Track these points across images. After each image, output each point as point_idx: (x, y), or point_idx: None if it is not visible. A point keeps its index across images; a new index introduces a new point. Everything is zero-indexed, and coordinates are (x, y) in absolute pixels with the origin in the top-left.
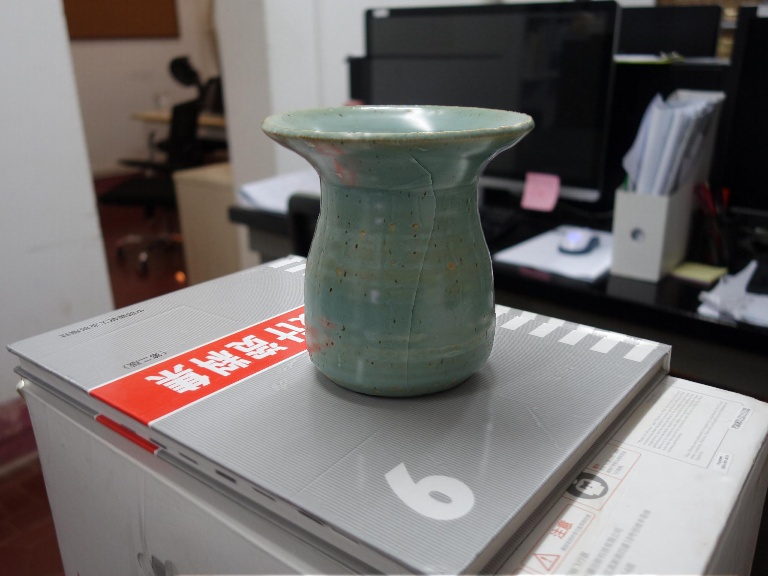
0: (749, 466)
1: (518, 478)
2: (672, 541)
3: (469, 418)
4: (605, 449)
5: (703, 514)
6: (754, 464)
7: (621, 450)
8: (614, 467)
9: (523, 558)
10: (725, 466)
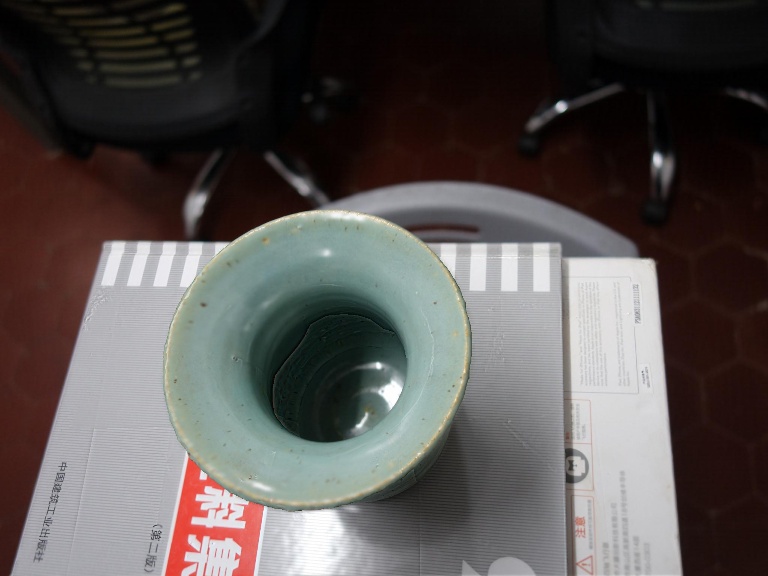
0: (663, 372)
1: (548, 529)
2: (649, 497)
3: (472, 469)
4: None
5: (656, 454)
6: None
7: (575, 404)
8: (580, 430)
9: (572, 572)
10: (649, 383)
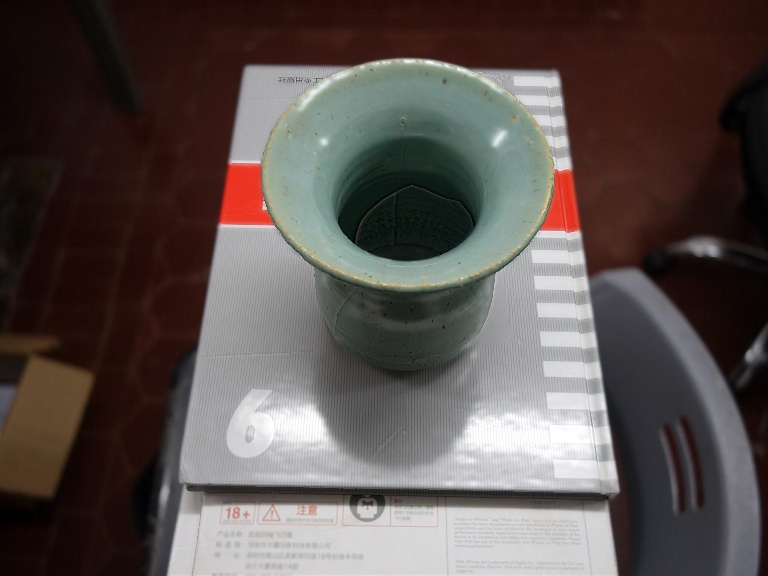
0: None
1: (300, 468)
2: None
3: (356, 397)
4: (426, 498)
5: None
6: None
7: (433, 510)
8: (405, 514)
9: (265, 501)
10: None
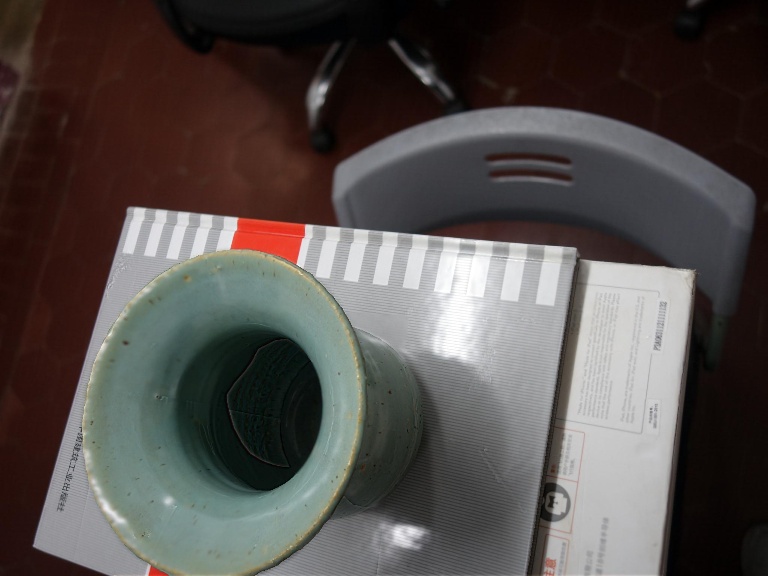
0: (676, 412)
1: (506, 572)
2: (631, 552)
3: (440, 494)
4: (554, 439)
5: (648, 506)
6: (680, 399)
7: (567, 434)
8: (567, 465)
9: None
10: (656, 424)
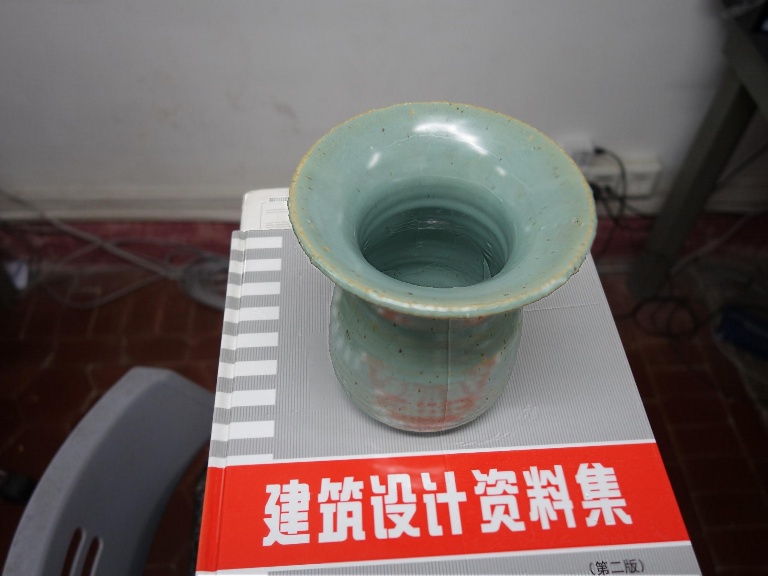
0: None
1: None
2: None
3: None
4: None
5: None
6: None
7: None
8: None
9: None
10: None
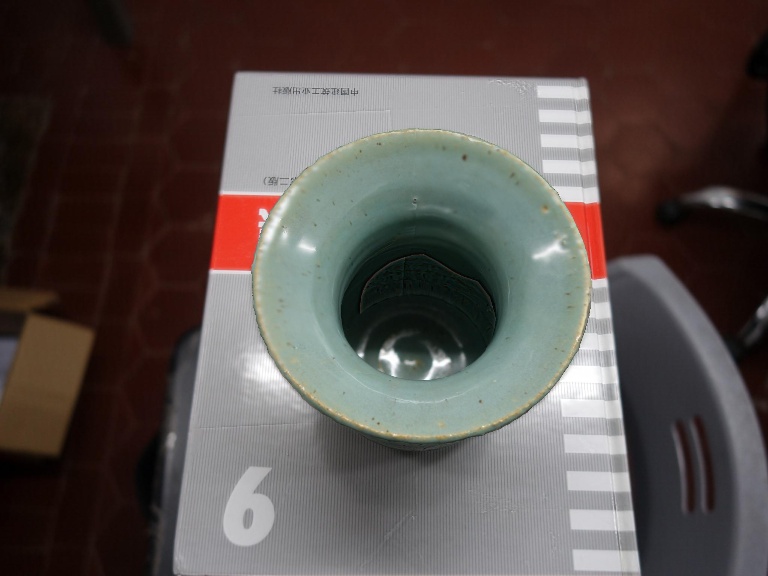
0: None
1: (302, 558)
2: None
3: (362, 476)
4: None
5: None
6: None
7: None
8: None
9: None
10: None
